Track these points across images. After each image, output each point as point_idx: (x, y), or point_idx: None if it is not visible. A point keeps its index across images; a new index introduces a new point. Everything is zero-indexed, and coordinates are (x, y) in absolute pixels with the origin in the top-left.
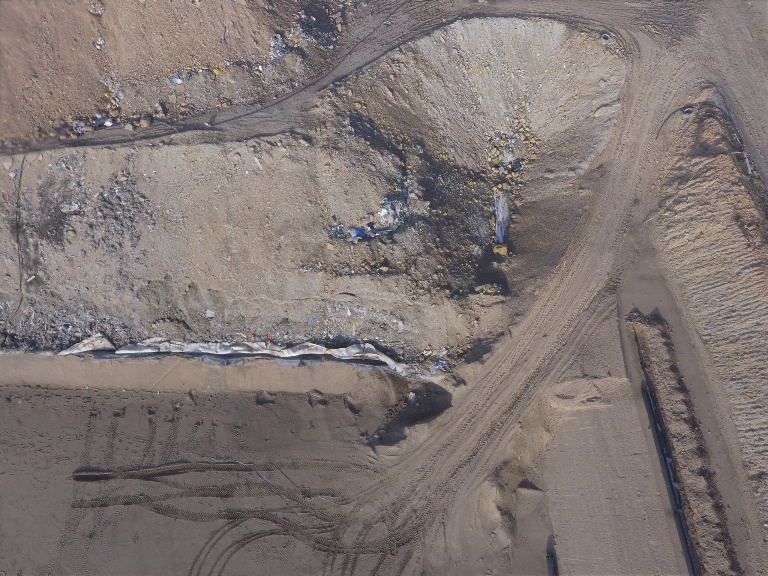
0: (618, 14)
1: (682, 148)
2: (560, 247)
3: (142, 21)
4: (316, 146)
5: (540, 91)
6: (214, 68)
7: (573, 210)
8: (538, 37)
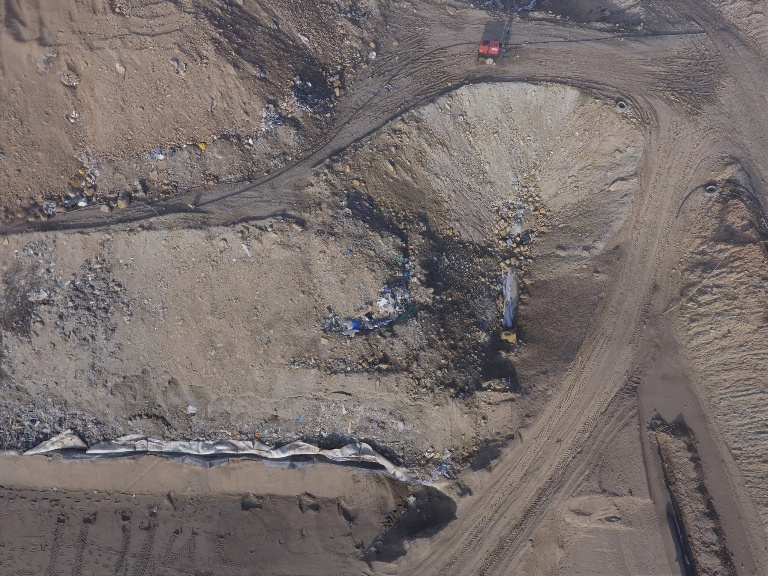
0: (634, 79)
1: (705, 230)
2: (574, 340)
3: (121, 93)
4: (310, 231)
5: (551, 159)
6: (200, 142)
7: (588, 296)
8: (549, 103)
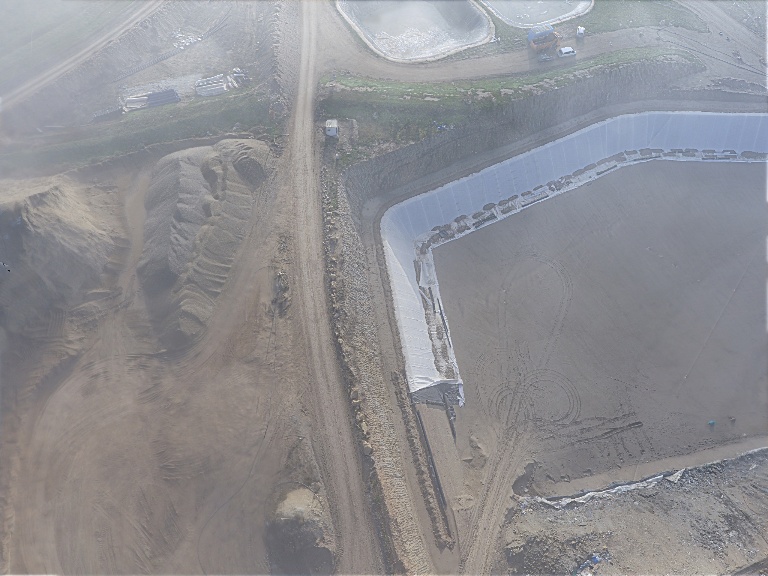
0: None
1: None
2: None
3: None
4: None
5: None
6: None
7: None
8: None
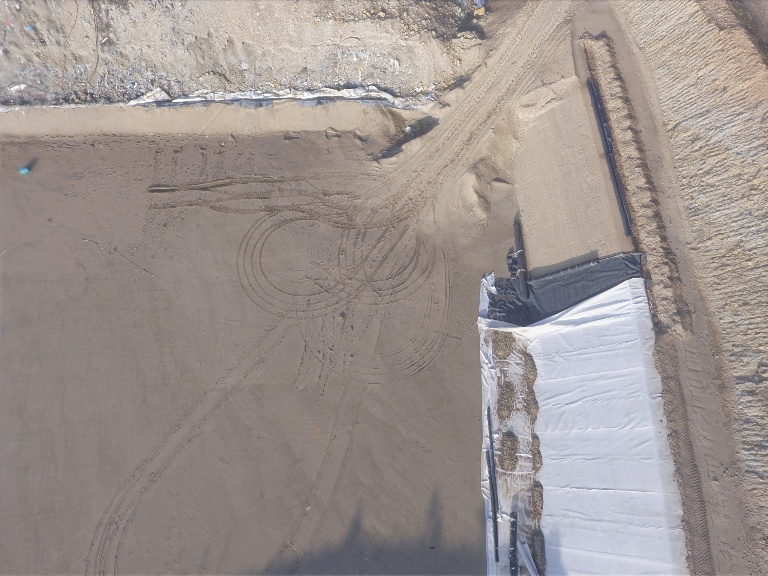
0: None
1: None
2: None
3: None
4: None
5: None
6: None
7: None
8: None
